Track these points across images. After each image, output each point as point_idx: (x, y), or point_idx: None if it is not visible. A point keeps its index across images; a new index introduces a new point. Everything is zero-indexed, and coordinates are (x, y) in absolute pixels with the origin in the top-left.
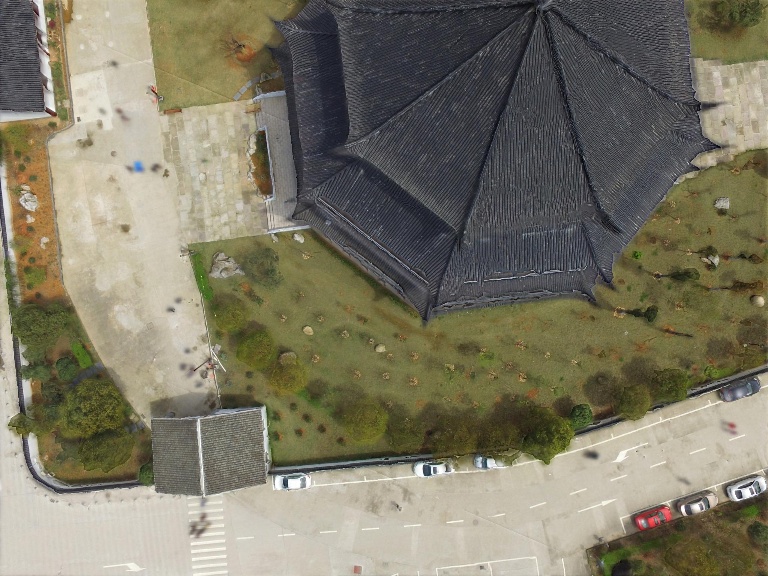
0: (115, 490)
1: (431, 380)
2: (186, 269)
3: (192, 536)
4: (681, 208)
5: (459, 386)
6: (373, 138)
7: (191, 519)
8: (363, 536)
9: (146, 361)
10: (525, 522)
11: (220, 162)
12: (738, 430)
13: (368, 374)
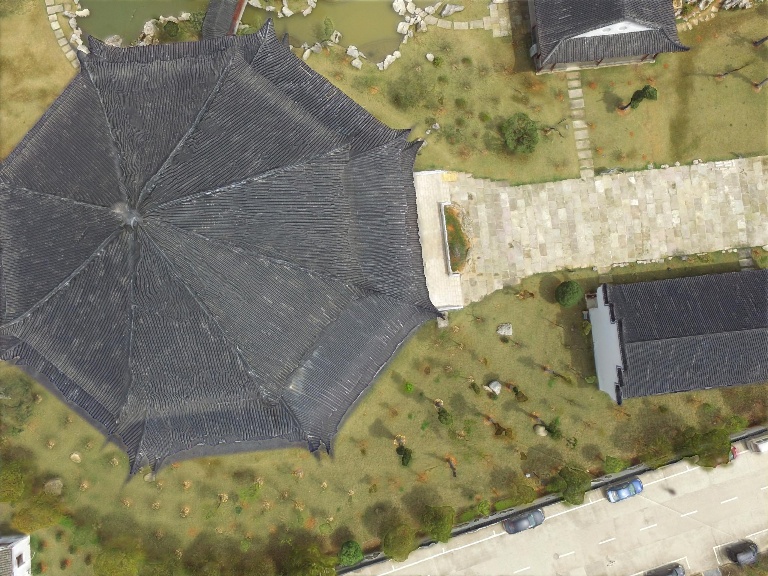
0: None
1: (203, 510)
2: None
3: None
4: (464, 333)
5: (231, 517)
6: (27, 319)
7: None
8: None
9: None
10: None
11: None
12: (523, 562)
13: (138, 504)
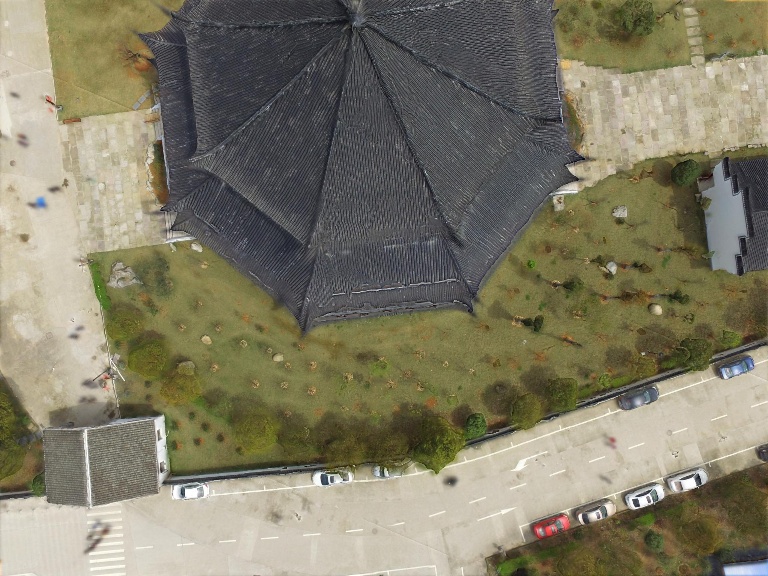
0: (14, 500)
1: (330, 389)
2: (85, 279)
3: (91, 546)
4: (580, 217)
5: (357, 395)
6: (219, 152)
7: (90, 529)
8: (262, 545)
9: (45, 371)
10: (424, 531)
11: (119, 171)
12: (638, 438)
13: (267, 383)
